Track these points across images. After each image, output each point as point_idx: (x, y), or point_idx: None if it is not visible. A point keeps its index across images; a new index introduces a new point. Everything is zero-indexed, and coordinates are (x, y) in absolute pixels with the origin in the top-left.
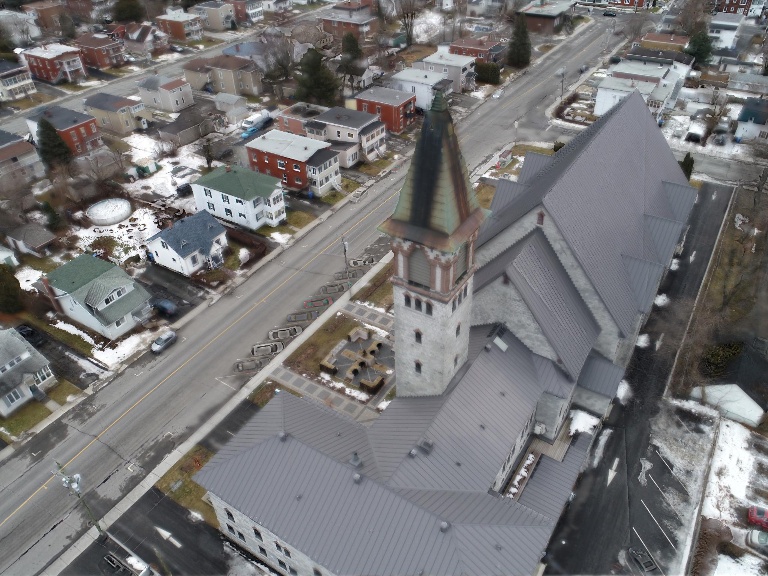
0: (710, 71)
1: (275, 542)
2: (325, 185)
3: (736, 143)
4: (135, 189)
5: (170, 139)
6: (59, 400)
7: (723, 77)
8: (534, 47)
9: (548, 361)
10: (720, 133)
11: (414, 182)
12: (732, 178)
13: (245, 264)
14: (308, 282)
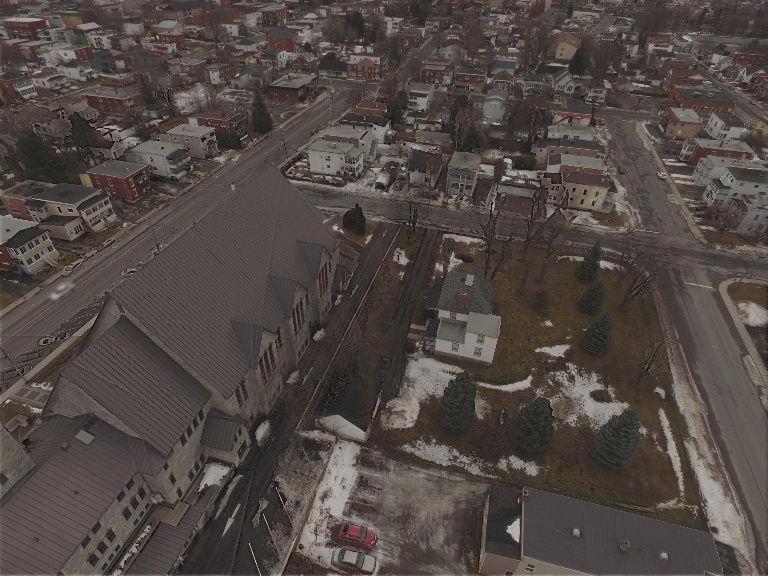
0: (407, 129)
1: None
2: (35, 262)
3: (411, 188)
4: None
5: None
6: None
7: (414, 134)
8: (281, 114)
9: (141, 441)
10: (401, 180)
11: None
12: (401, 217)
13: None
14: None
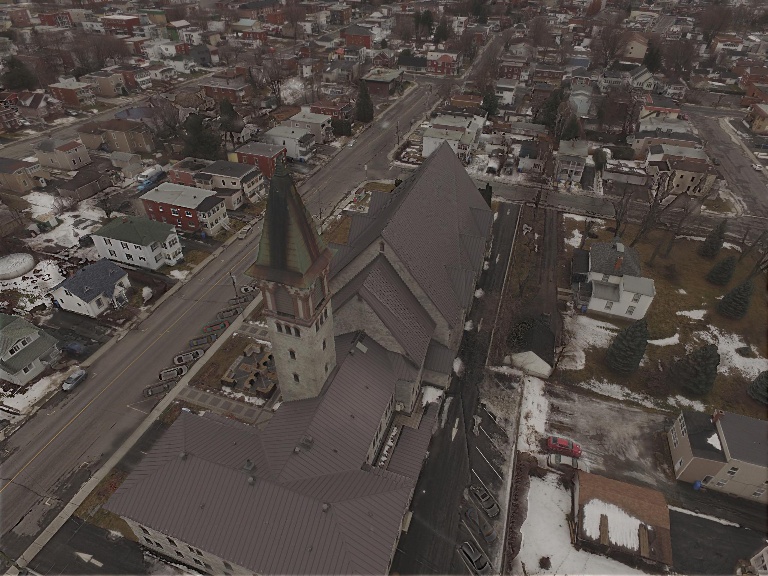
0: (499, 121)
1: (187, 546)
2: (215, 226)
3: (520, 173)
4: (37, 243)
5: (69, 195)
6: None
7: (508, 125)
8: (376, 106)
9: (399, 355)
10: (509, 166)
11: (269, 234)
12: (519, 198)
13: (148, 301)
14: (206, 310)
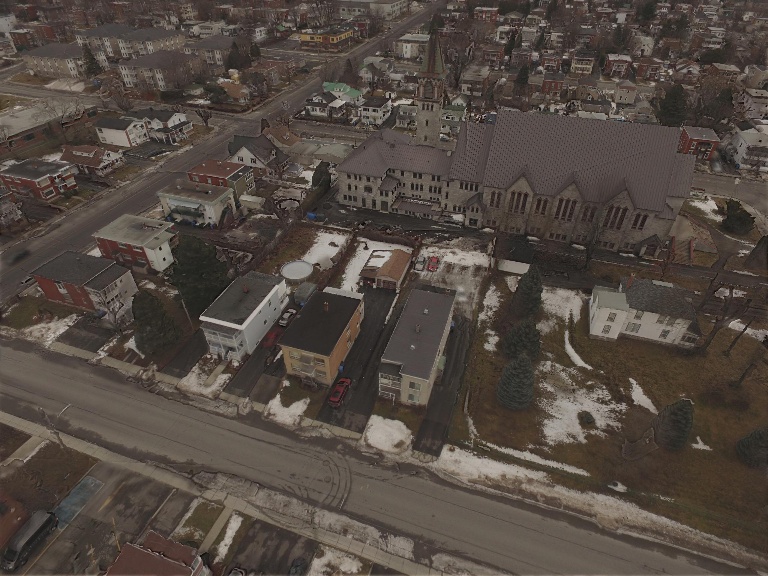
0: None
1: None
2: None
3: None
4: None
5: None
6: (408, 132)
7: None
8: None
9: None
10: None
11: None
12: None
13: None
14: None
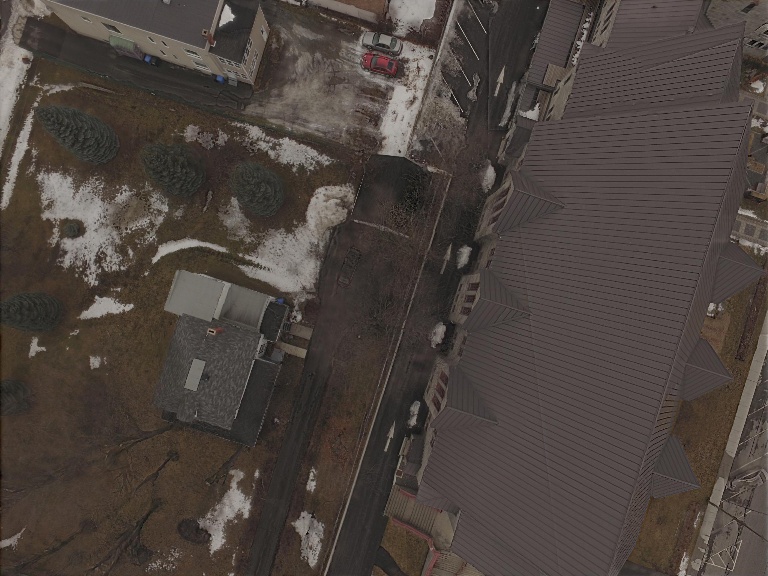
0: None
1: None
2: None
3: None
4: None
5: None
6: None
7: None
8: None
9: None
10: None
11: None
12: None
13: None
14: None
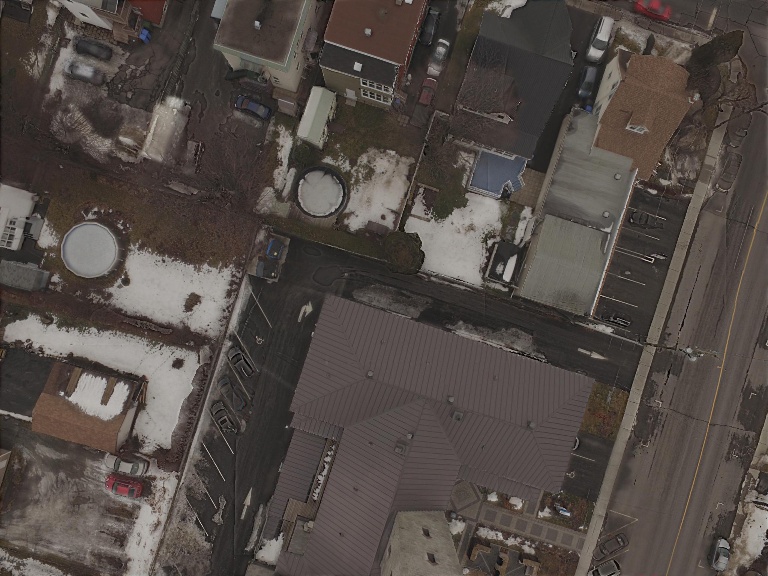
0: None
1: None
2: None
3: None
4: None
5: None
6: None
7: None
8: None
9: None
10: None
11: None
12: None
13: None
14: None
